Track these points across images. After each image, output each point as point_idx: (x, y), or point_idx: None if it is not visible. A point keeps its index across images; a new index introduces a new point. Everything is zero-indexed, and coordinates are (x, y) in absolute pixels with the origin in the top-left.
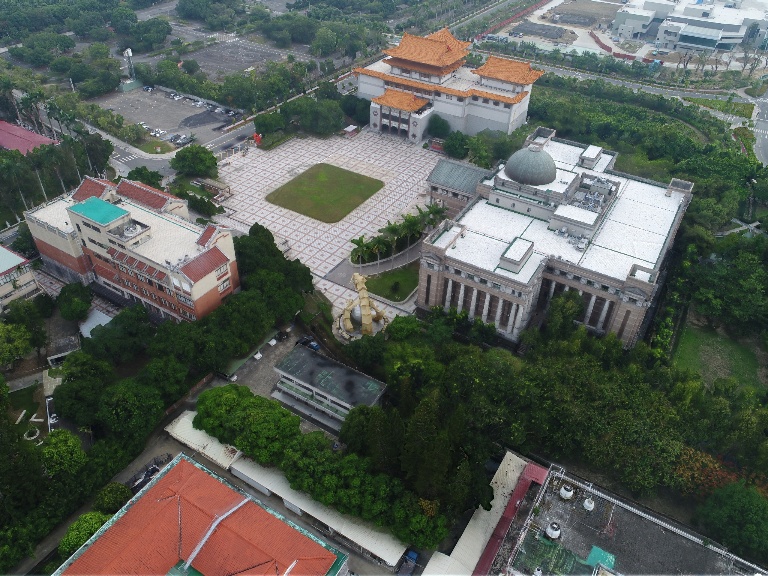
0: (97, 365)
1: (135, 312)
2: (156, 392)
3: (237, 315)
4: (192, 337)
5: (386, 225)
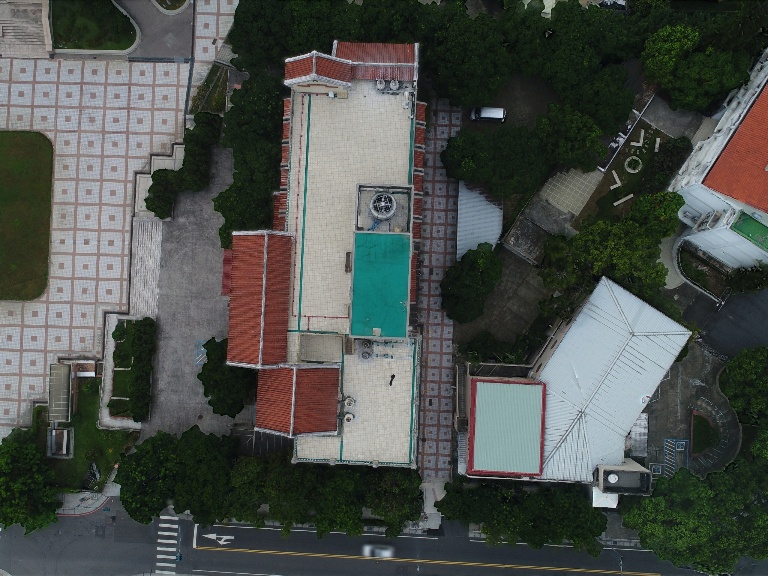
0: (561, 116)
1: (466, 144)
2: (561, 3)
3: (401, 2)
4: (472, 20)
5: (5, 53)
